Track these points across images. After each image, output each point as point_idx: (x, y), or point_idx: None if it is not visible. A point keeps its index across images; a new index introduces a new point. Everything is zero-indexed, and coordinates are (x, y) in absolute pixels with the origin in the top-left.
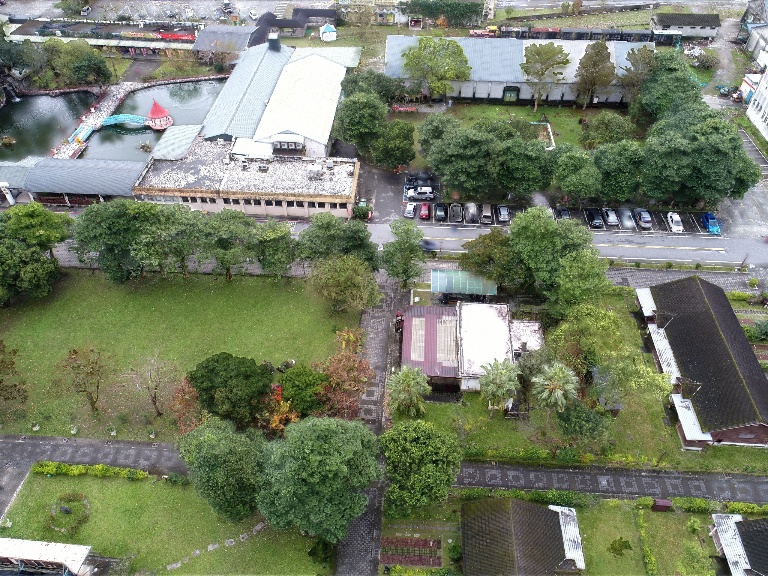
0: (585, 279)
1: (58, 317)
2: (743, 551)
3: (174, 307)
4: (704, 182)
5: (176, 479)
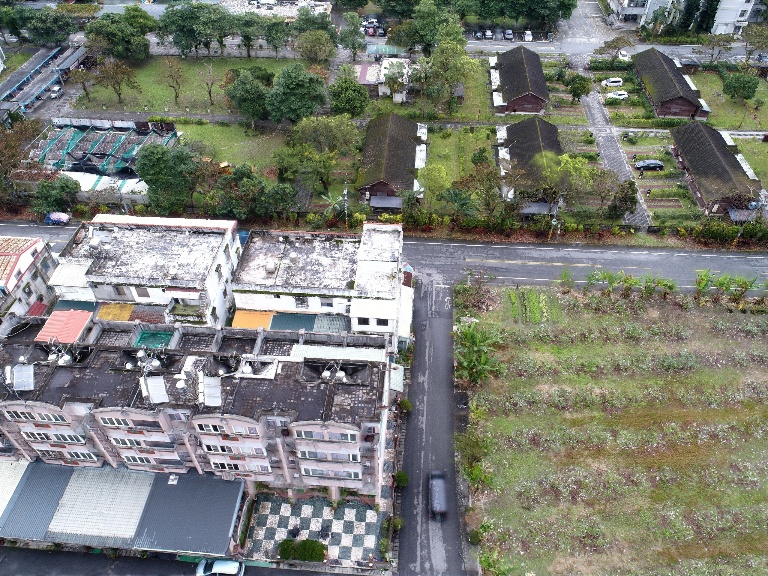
0: (450, 36)
1: (150, 73)
2: (506, 135)
3: (217, 69)
4: (541, 4)
5: (223, 121)
